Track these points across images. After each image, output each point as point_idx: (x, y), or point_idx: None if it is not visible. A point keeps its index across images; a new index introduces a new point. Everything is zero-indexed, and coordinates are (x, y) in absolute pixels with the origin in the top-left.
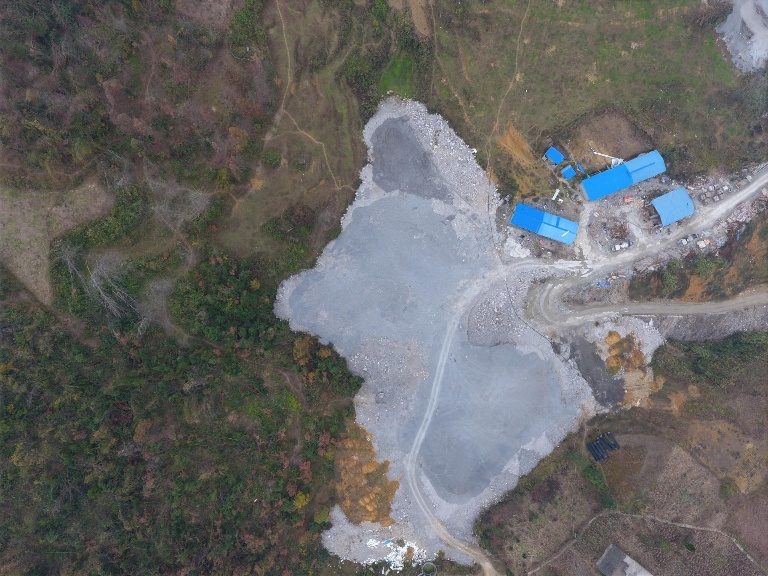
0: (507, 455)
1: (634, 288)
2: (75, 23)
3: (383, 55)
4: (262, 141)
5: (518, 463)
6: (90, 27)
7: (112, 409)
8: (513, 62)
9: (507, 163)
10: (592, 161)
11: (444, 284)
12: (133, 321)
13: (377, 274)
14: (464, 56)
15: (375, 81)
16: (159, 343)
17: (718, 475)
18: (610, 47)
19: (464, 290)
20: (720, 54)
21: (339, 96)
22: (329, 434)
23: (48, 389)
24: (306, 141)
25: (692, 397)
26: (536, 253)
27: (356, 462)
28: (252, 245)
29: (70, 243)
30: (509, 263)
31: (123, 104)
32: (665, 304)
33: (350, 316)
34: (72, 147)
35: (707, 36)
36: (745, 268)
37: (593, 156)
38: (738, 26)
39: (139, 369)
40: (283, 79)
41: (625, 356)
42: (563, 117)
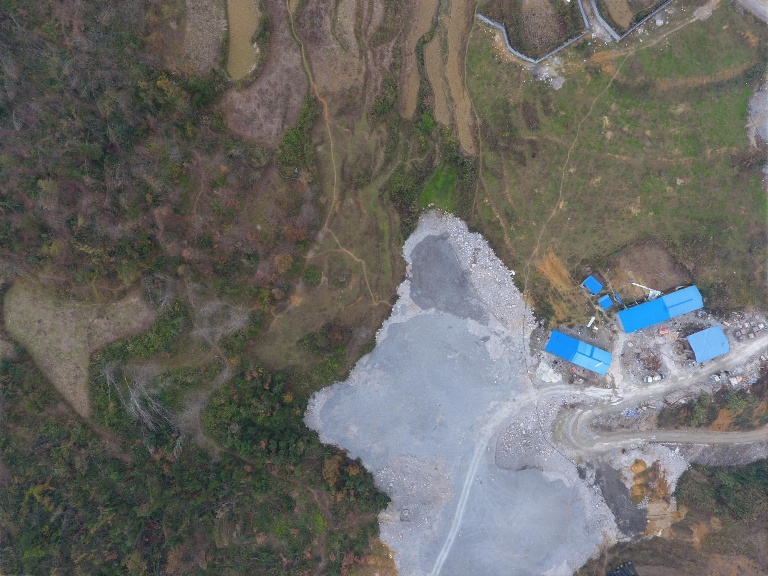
0: None
1: (663, 417)
2: (128, 142)
3: (427, 170)
4: (304, 259)
5: None
6: (142, 146)
7: (144, 529)
8: (557, 190)
9: (545, 288)
10: (630, 292)
11: (475, 405)
12: (167, 433)
13: (409, 391)
14: (508, 179)
15: (417, 194)
16: (191, 457)
17: None
18: (656, 182)
19: (494, 412)
20: (765, 195)
21: (382, 213)
22: (353, 553)
23: (82, 508)
24: (347, 259)
25: (714, 529)
26: (568, 379)
27: None
28: (287, 358)
29: (110, 356)
30: (540, 387)
31: (170, 221)
32: (692, 432)
33: (380, 432)
34: (118, 263)
35: (753, 176)
36: None
37: (631, 287)
38: None
39: (172, 490)
40: (328, 197)
41: (650, 486)
42: (604, 247)
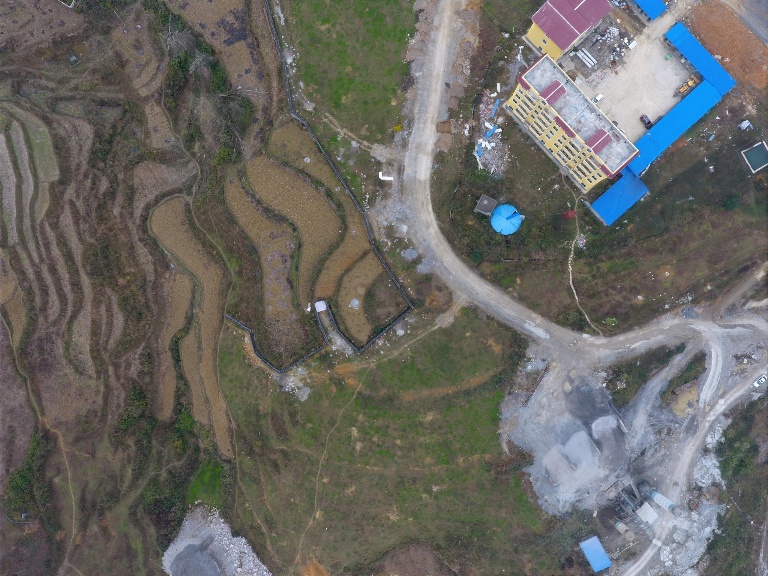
0: None
1: None
2: None
3: (187, 472)
4: None
5: None
6: None
7: None
8: (312, 500)
9: None
10: None
11: None
12: None
13: None
14: (265, 485)
15: (181, 495)
16: None
17: None
18: (411, 490)
19: None
20: (526, 495)
21: (133, 531)
22: None
23: None
24: None
25: None
26: None
27: None
28: None
29: None
30: None
31: None
32: None
33: None
34: None
35: (513, 476)
36: None
37: None
38: (542, 471)
39: None
40: (67, 531)
41: None
42: (365, 555)
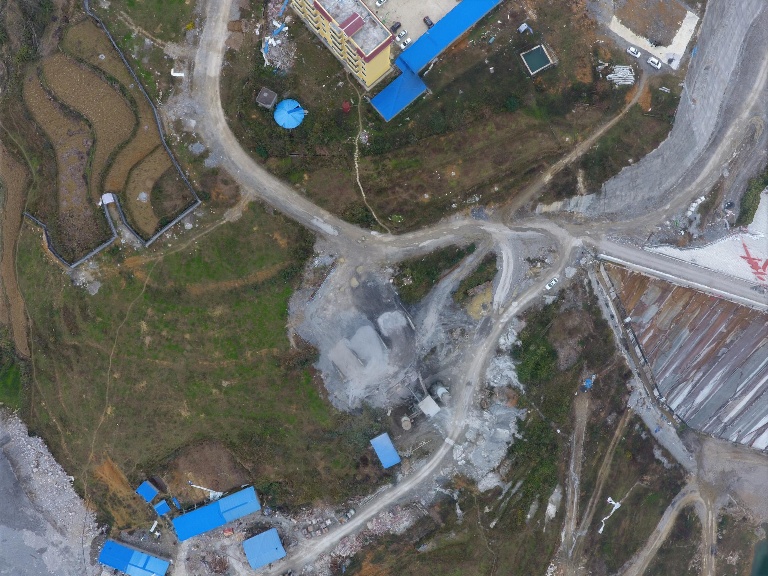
0: None
1: None
2: None
3: None
4: None
5: None
6: None
7: None
8: (103, 396)
9: (102, 494)
10: (189, 494)
11: None
12: None
13: None
14: (60, 382)
15: None
16: None
17: None
18: (201, 385)
19: None
20: (316, 392)
21: None
22: None
23: None
24: None
25: None
26: None
27: None
28: None
29: None
30: None
31: None
32: None
33: None
34: None
35: (304, 373)
36: None
37: (191, 489)
38: (331, 367)
39: None
40: None
41: None
42: (157, 451)
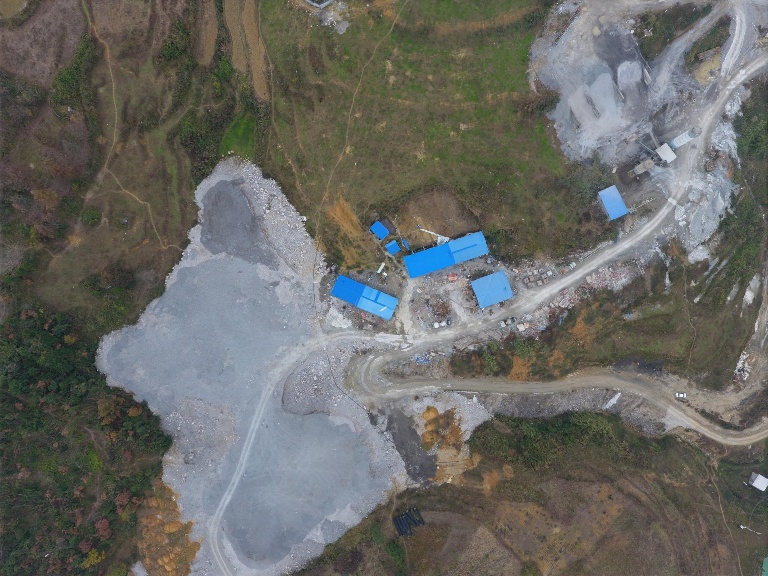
0: (308, 525)
1: (456, 365)
2: None
3: (223, 116)
4: (82, 199)
5: (321, 533)
6: None
7: None
8: (344, 135)
9: (334, 233)
10: (418, 237)
11: (263, 350)
12: None
13: (197, 335)
14: (299, 124)
15: (215, 141)
16: None
17: (521, 558)
18: (439, 127)
19: (282, 357)
20: (549, 141)
21: (170, 157)
22: (129, 493)
23: None
24: (130, 201)
25: (506, 477)
26: (358, 324)
27: (159, 521)
28: (71, 300)
29: None
30: (330, 333)
31: None
32: (490, 381)
33: (166, 375)
34: None
35: (538, 122)
36: (572, 351)
37: (419, 232)
38: (567, 115)
39: None
40: (109, 139)
41: (440, 432)
42: (391, 192)
